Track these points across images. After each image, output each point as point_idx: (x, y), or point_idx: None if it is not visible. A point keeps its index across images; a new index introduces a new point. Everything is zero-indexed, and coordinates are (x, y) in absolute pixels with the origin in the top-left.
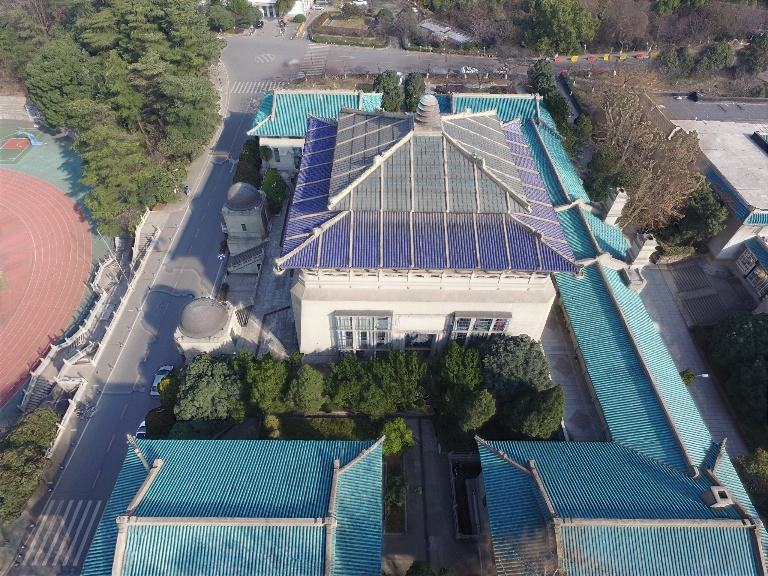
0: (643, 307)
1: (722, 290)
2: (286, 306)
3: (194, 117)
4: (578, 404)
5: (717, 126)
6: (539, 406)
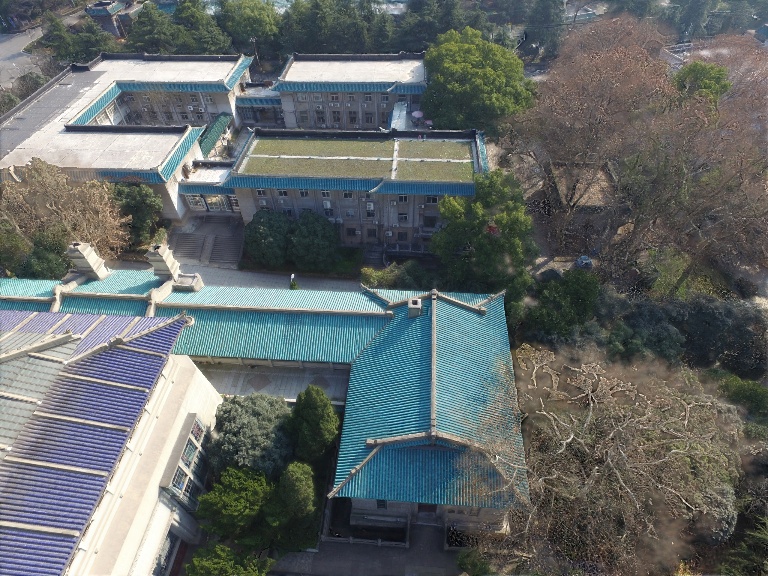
0: (223, 288)
1: (213, 231)
2: None
3: None
4: (302, 382)
5: (33, 143)
6: (316, 416)
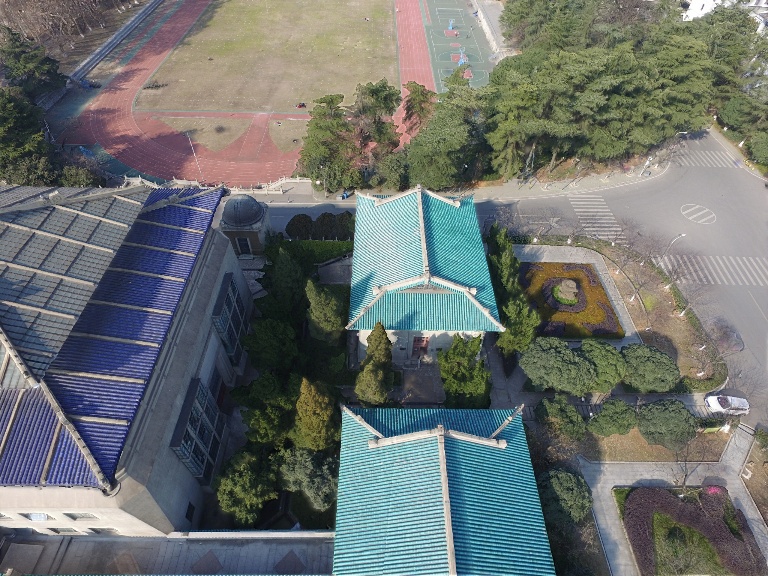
0: None
1: None
2: None
3: (410, 155)
4: None
5: None
6: None
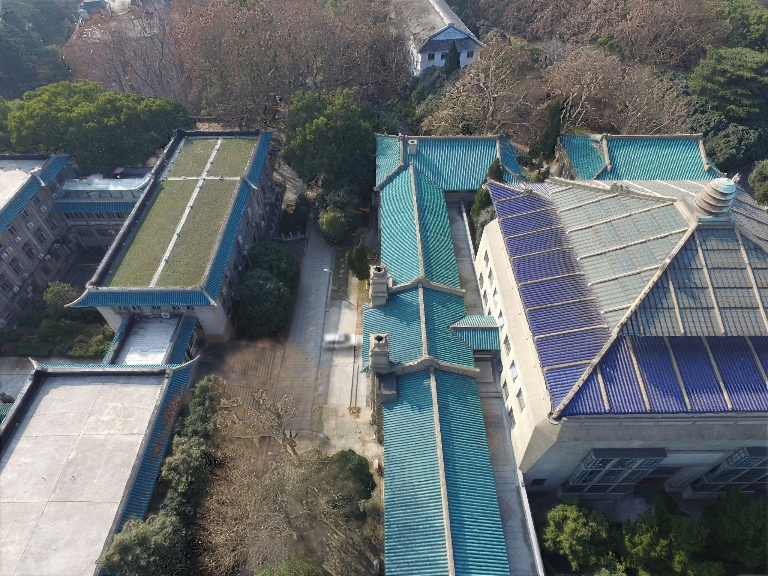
0: None
1: None
2: None
3: None
4: None
5: None
6: None
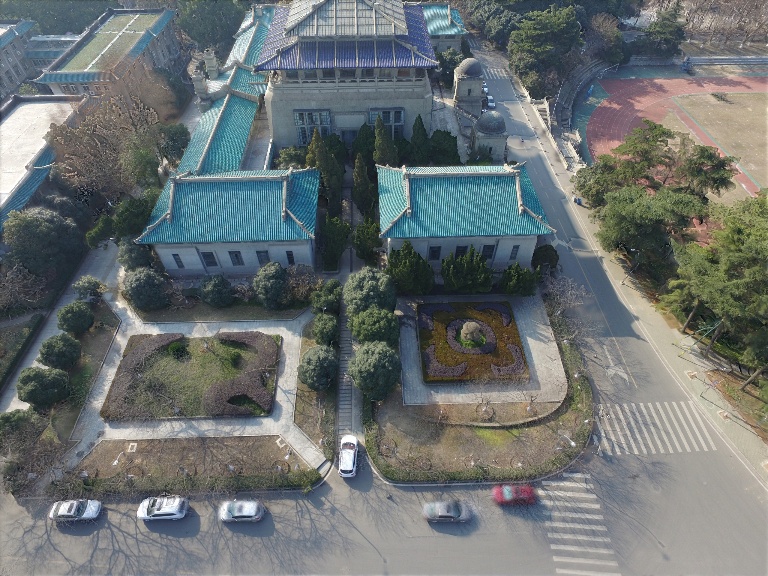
0: None
1: None
2: (434, 111)
3: None
4: None
5: None
6: None
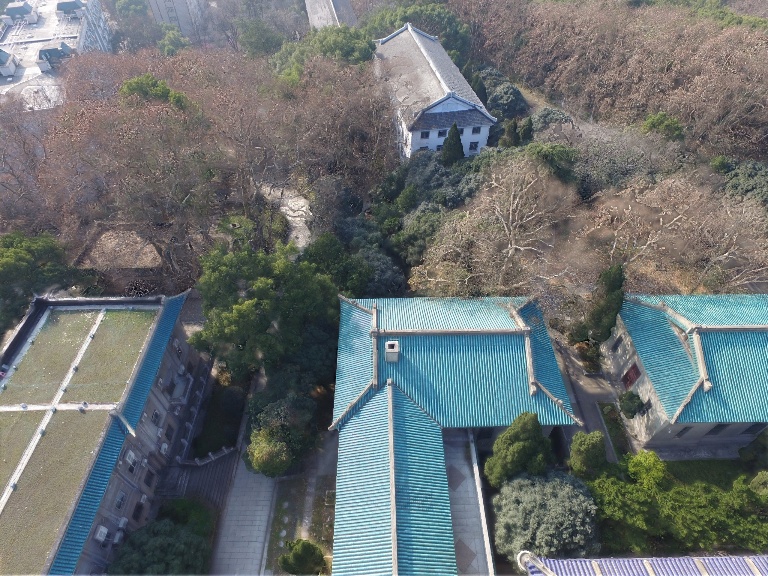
0: None
1: None
2: None
3: None
4: (452, 498)
5: None
6: None
